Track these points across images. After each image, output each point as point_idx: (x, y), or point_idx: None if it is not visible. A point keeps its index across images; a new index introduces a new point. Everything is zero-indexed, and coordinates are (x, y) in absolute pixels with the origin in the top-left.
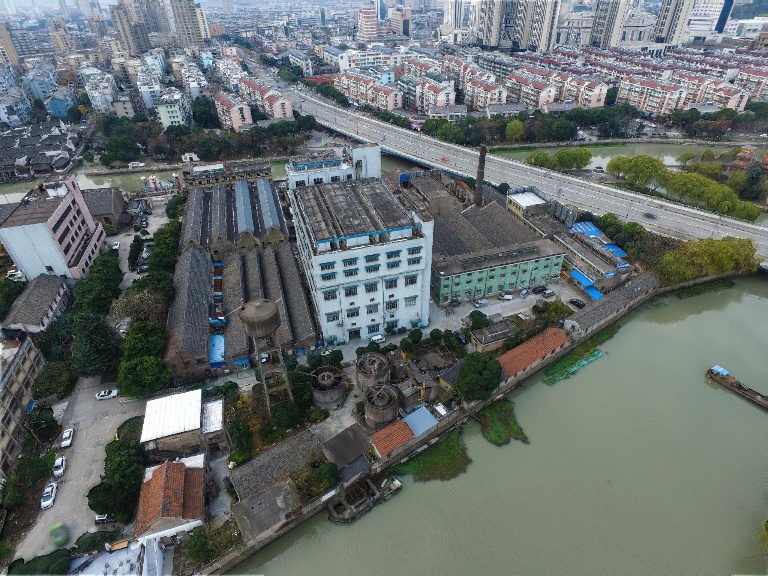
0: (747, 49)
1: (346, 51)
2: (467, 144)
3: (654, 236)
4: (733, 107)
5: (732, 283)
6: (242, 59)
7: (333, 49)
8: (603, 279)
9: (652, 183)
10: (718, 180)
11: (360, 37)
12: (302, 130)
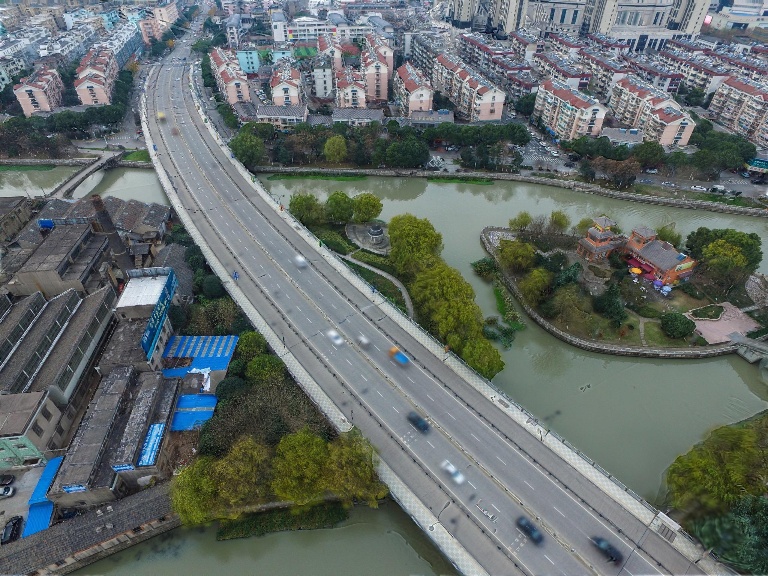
0: (767, 47)
1: (289, 19)
2: (279, 162)
3: (292, 387)
4: (671, 138)
5: (343, 517)
6: (165, 22)
7: (277, 15)
8: (66, 493)
9: (411, 269)
10: (521, 274)
11: (338, 2)
12: (94, 124)
